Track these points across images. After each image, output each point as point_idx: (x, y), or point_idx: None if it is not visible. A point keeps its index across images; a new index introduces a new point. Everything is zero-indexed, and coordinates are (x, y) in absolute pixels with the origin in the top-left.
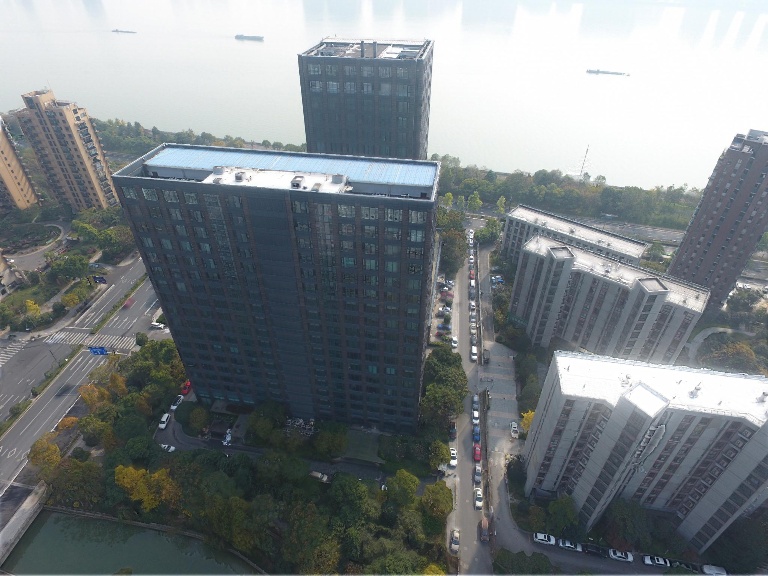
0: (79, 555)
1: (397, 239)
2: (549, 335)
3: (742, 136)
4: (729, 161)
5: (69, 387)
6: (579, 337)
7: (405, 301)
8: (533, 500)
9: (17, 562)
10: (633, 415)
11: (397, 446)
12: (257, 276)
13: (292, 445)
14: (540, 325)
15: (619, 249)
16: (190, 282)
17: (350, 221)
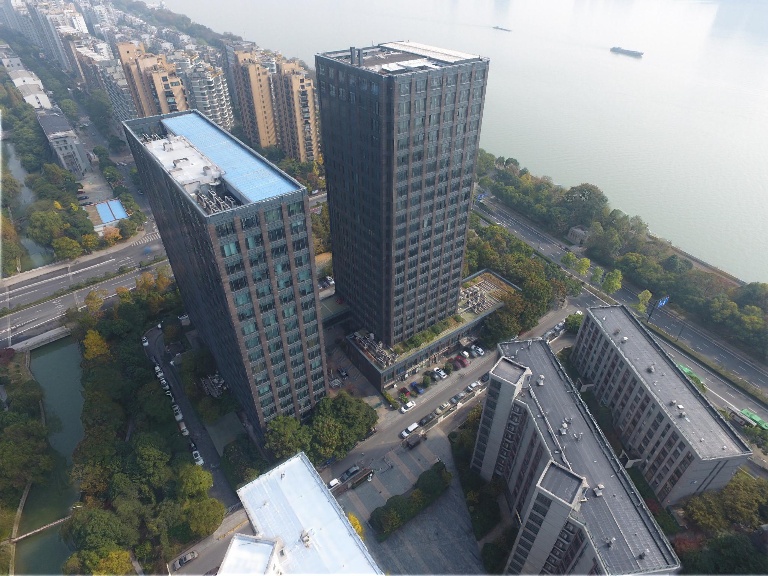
0: (67, 373)
1: None
2: (491, 468)
3: None
4: None
5: None
6: (517, 495)
7: (225, 311)
8: None
9: (44, 355)
10: None
11: (231, 449)
12: None
13: (186, 391)
14: (479, 447)
15: (687, 430)
16: None
17: None
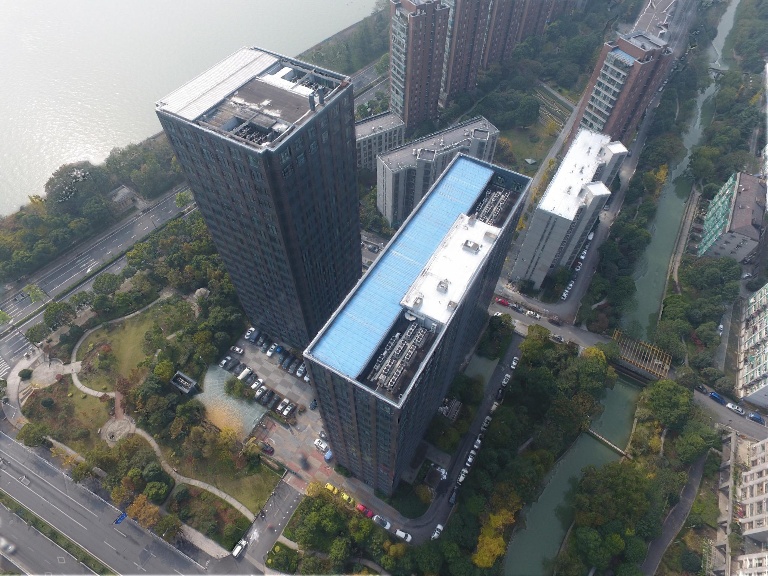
0: None
1: None
2: None
3: (395, 1)
4: (416, 25)
5: None
6: None
7: None
8: (541, 288)
9: None
10: (600, 200)
11: None
12: None
13: None
14: None
15: (390, 126)
16: None
17: (503, 237)
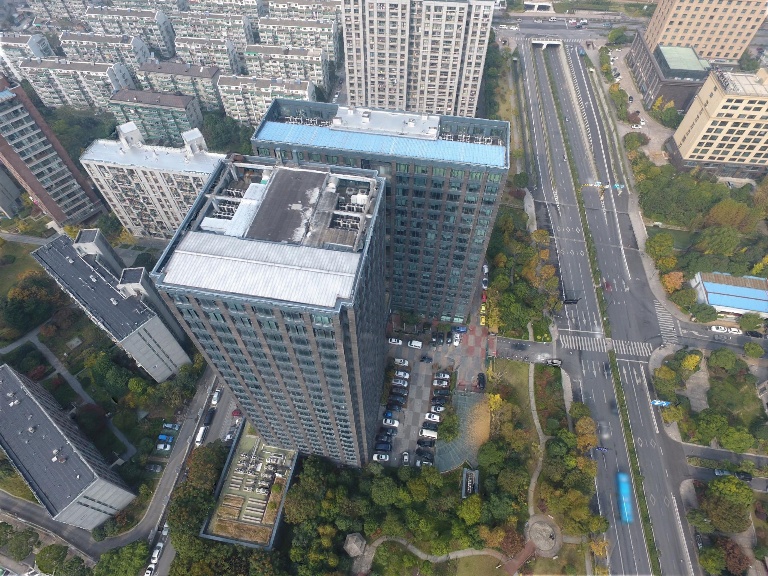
0: None
1: None
2: None
3: None
4: None
5: (580, 297)
6: None
7: None
8: None
9: None
10: None
11: None
12: None
13: None
14: None
15: None
16: None
17: None
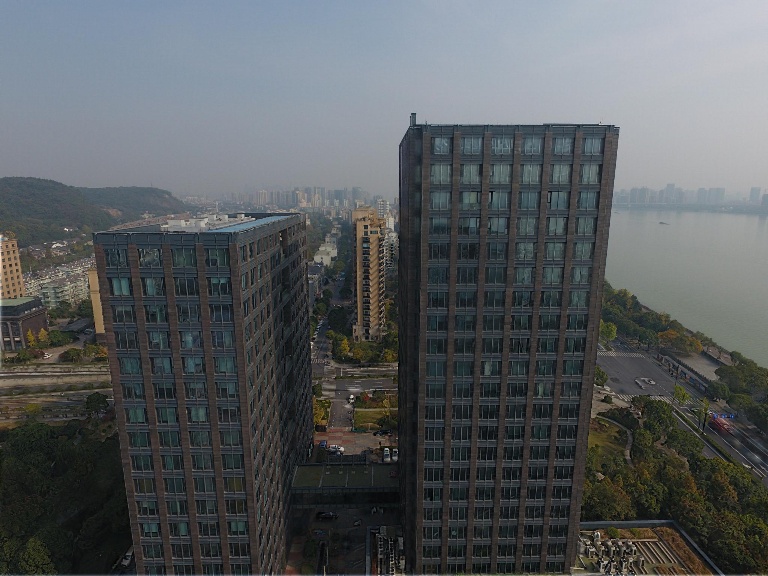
0: None
1: None
2: None
3: None
4: None
5: None
6: None
7: None
8: None
9: None
10: None
11: None
12: None
13: None
14: None
15: None
16: None
17: None
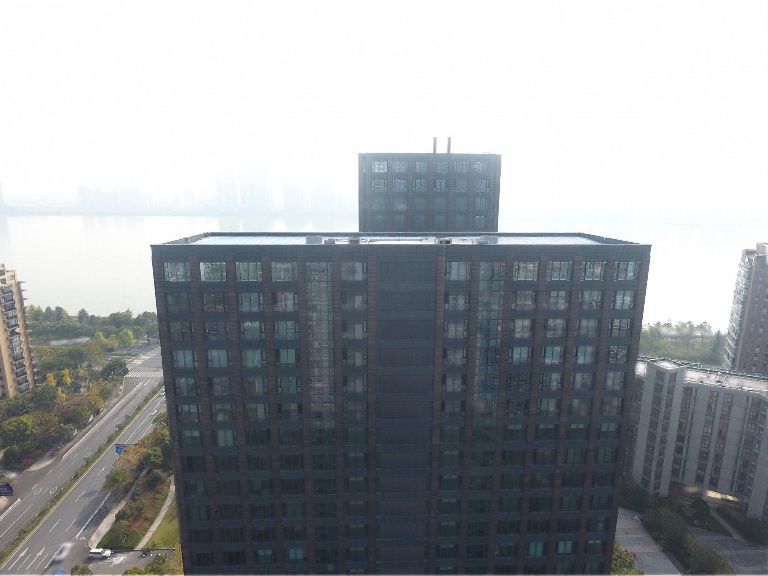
0: None
1: (595, 308)
2: (667, 479)
3: None
4: (761, 267)
5: None
6: (705, 476)
7: (599, 411)
8: None
9: None
10: None
11: None
12: (368, 398)
13: None
14: (657, 466)
15: None
16: (244, 426)
17: (530, 286)
